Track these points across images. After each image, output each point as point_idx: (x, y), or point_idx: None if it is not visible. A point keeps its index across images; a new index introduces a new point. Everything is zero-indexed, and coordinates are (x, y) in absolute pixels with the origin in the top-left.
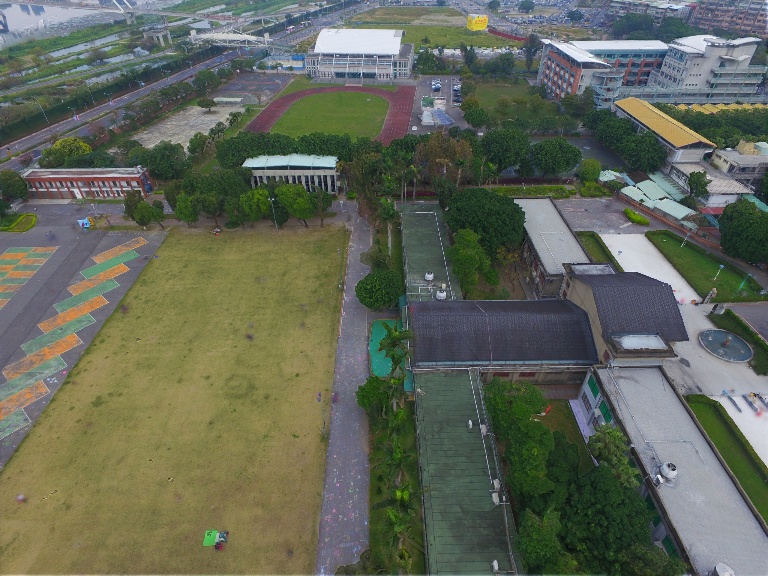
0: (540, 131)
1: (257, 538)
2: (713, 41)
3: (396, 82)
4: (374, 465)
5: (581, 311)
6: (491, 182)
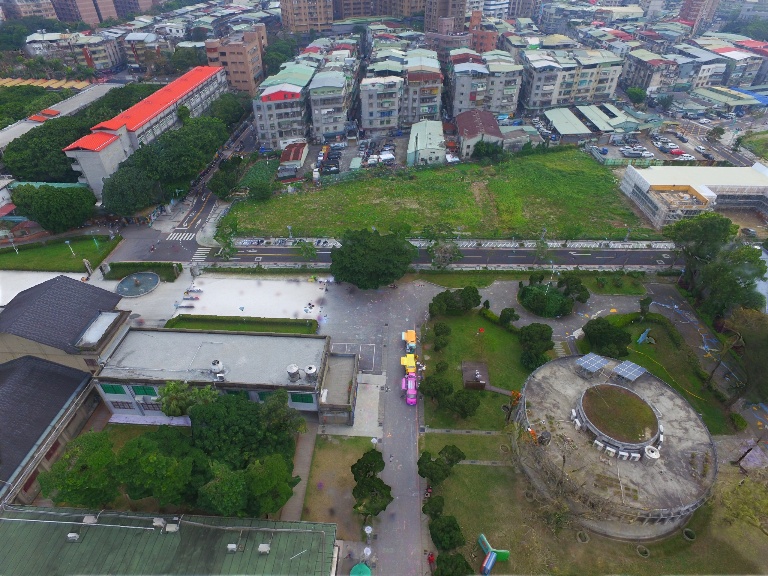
0: None
1: None
2: None
3: None
4: None
5: (21, 360)
6: None
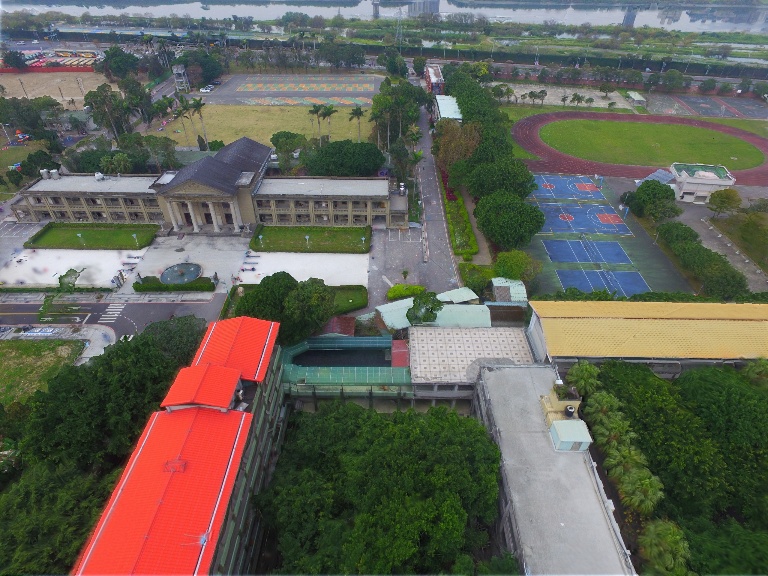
0: None
1: None
2: None
3: None
4: None
5: None
6: None
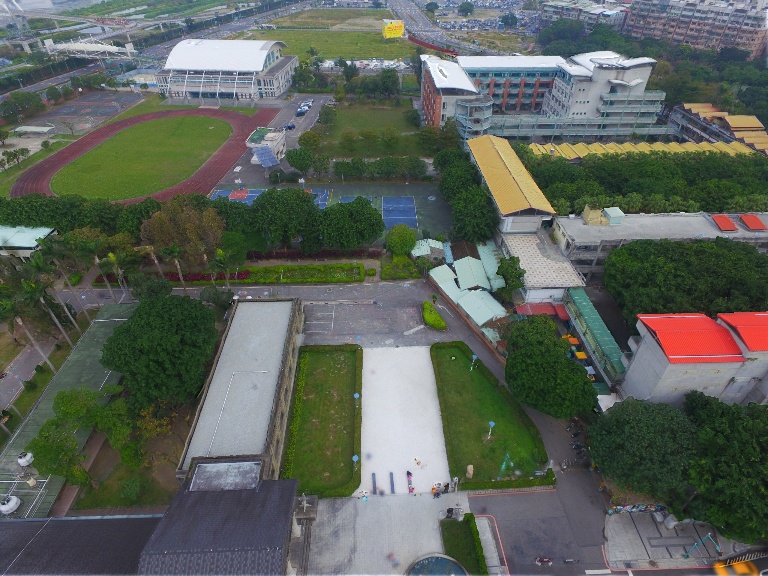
0: None
1: None
2: (600, 62)
3: (259, 103)
4: None
5: None
6: (272, 257)
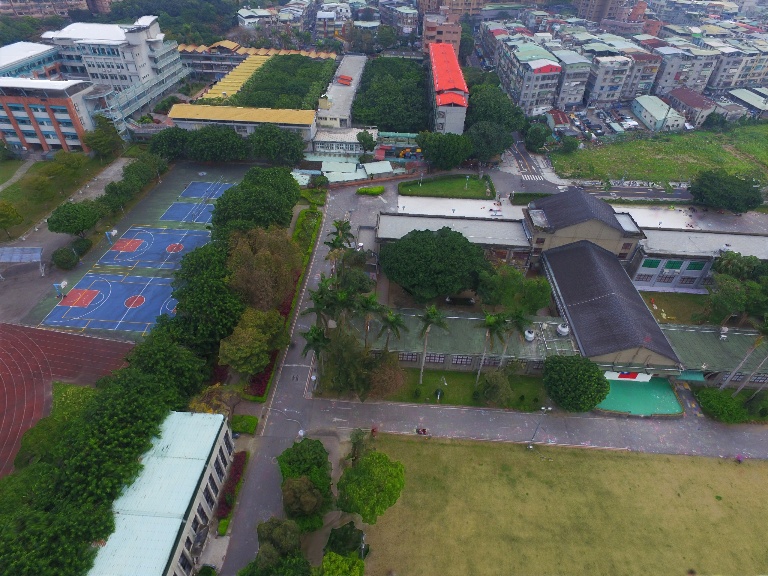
0: None
1: None
2: (128, 27)
3: None
4: None
5: (580, 243)
6: None
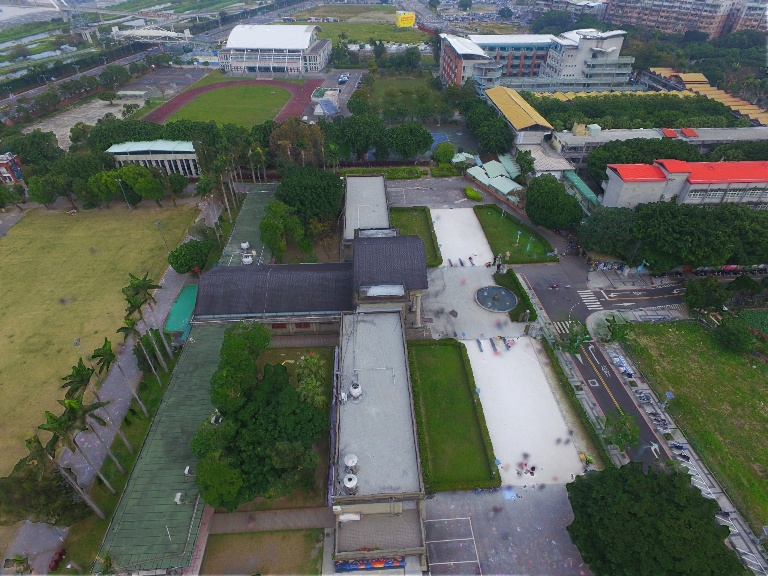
0: (419, 119)
1: (2, 463)
2: (584, 34)
3: (306, 76)
4: (135, 403)
5: None
6: (352, 165)
